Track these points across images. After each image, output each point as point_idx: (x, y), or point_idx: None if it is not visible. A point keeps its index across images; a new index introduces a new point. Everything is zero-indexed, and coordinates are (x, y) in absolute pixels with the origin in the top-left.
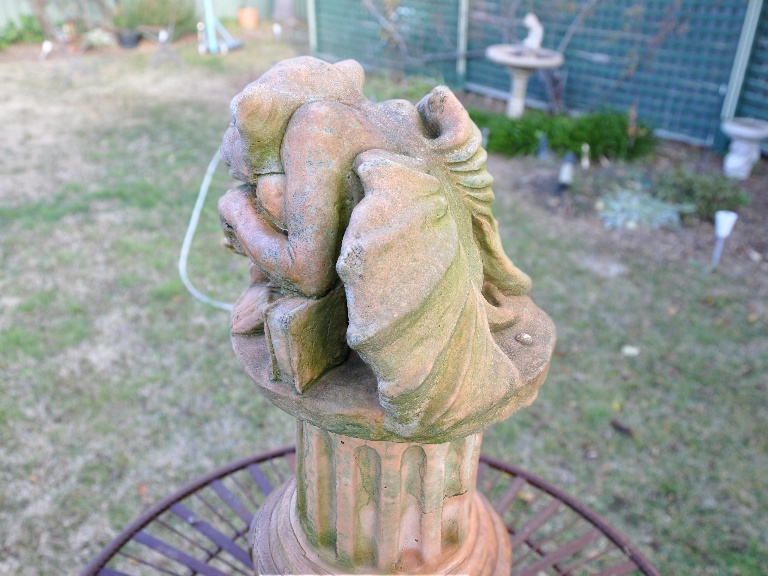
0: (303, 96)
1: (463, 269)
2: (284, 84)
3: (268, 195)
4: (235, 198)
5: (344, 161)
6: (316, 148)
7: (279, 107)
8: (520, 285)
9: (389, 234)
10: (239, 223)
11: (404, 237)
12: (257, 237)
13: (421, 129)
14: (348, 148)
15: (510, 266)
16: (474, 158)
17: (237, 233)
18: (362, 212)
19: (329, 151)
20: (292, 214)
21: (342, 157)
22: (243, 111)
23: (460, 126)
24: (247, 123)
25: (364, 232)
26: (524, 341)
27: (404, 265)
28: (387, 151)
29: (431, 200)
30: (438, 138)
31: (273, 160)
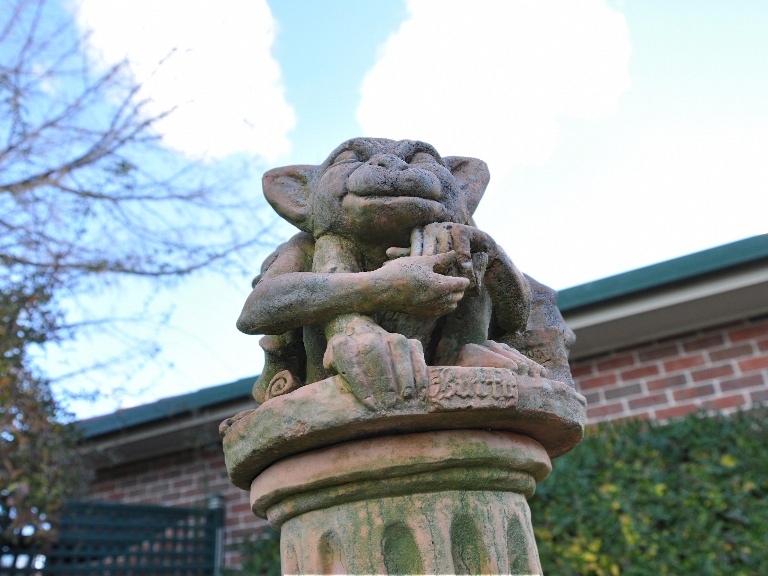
0: None
1: None
2: None
3: None
4: None
5: None
6: None
7: None
8: None
9: None
10: None
11: None
12: None
13: None
14: None
15: None
16: None
17: (512, 262)
18: None
19: None
20: None
21: None
22: None
23: None
24: None
25: None
26: None
27: None
28: None
29: None
30: None
31: None
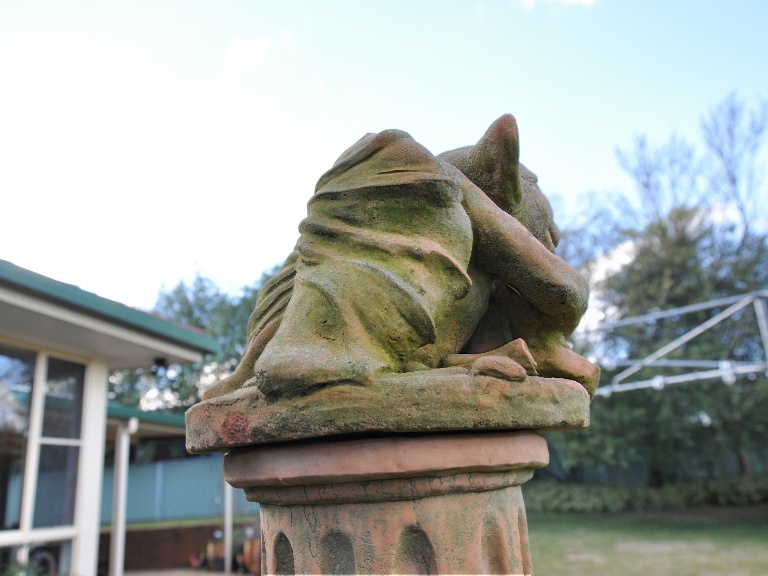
0: None
1: None
2: None
3: None
4: None
5: None
6: None
7: None
8: None
9: None
10: None
11: None
12: None
13: None
14: None
15: None
16: None
17: None
18: None
19: None
20: None
21: None
22: None
23: None
24: None
25: None
26: None
27: None
28: None
29: None
30: None
31: None
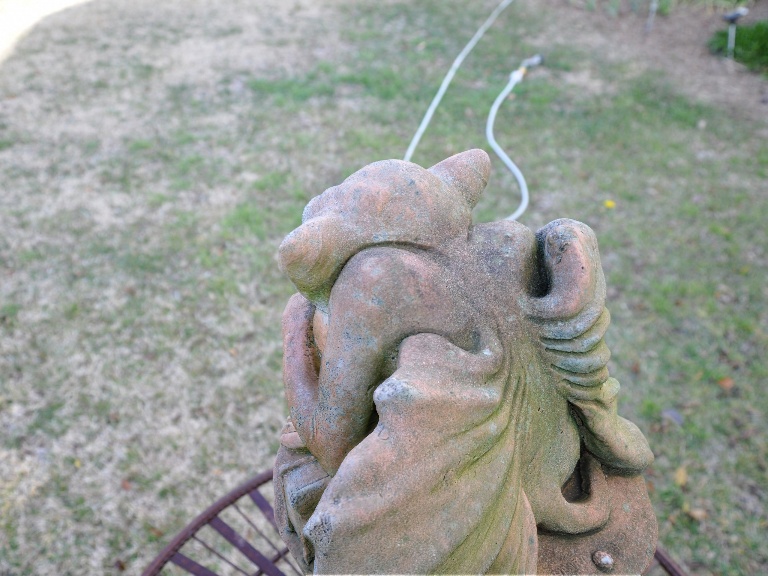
0: (370, 233)
1: (499, 522)
2: (353, 212)
3: (319, 332)
4: (296, 312)
5: (389, 341)
6: (356, 320)
7: (332, 251)
8: (633, 468)
9: (372, 512)
10: (285, 353)
11: (396, 513)
12: (293, 383)
13: (528, 276)
14: (396, 326)
15: (621, 448)
16: (585, 335)
17: None
18: (351, 468)
19: (372, 327)
20: (321, 384)
21: (387, 336)
22: (282, 259)
23: (574, 292)
24: (288, 270)
25: (345, 497)
26: (600, 566)
27: (387, 548)
28: (442, 342)
29: (470, 436)
30: (542, 299)
31: (324, 302)
